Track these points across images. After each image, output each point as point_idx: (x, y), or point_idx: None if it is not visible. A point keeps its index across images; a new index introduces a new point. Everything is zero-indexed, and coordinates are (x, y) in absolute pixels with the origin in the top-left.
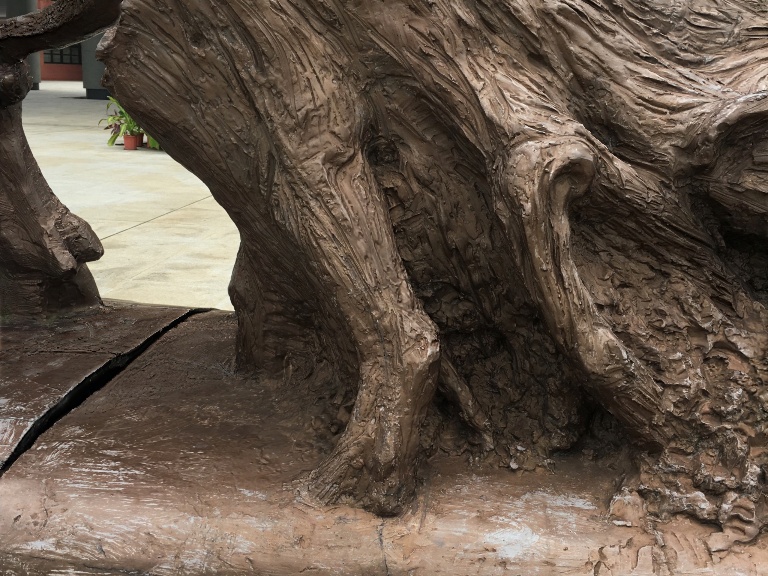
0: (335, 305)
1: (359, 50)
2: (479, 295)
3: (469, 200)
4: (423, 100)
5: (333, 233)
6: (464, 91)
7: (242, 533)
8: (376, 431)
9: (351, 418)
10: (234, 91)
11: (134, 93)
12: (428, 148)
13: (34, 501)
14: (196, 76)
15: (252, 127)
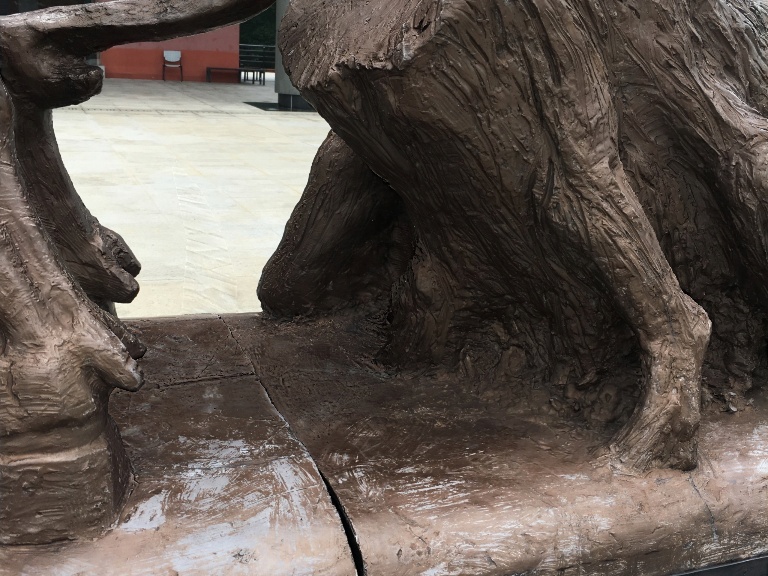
0: (621, 294)
1: (613, 61)
2: (677, 271)
3: (679, 191)
4: (657, 106)
5: (626, 230)
6: (699, 99)
7: (597, 512)
8: (680, 399)
9: (652, 392)
10: (525, 101)
11: (425, 103)
12: (650, 148)
13: (402, 532)
14: (493, 86)
15: (536, 135)
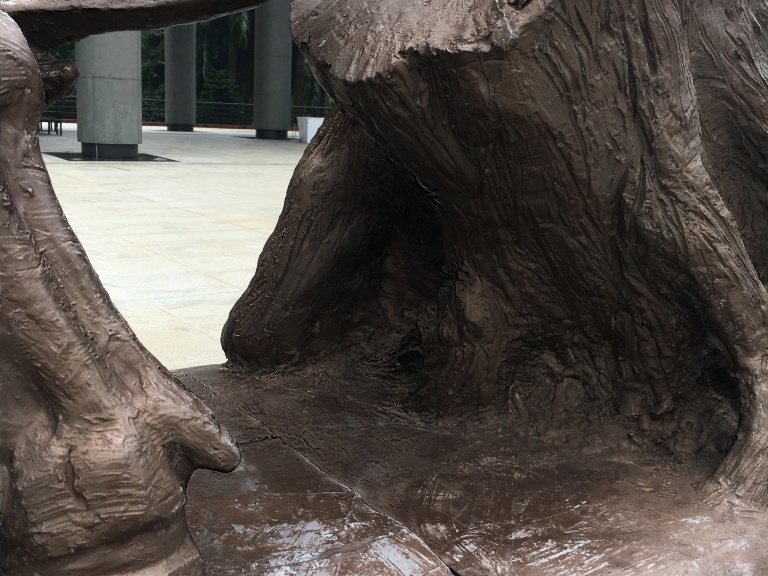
0: (719, 307)
1: None
2: None
3: (738, 195)
4: (723, 101)
5: (724, 235)
6: (764, 93)
7: (736, 558)
8: None
9: (759, 414)
10: (622, 91)
11: (524, 92)
12: (713, 148)
13: None
14: (592, 73)
15: (630, 130)
